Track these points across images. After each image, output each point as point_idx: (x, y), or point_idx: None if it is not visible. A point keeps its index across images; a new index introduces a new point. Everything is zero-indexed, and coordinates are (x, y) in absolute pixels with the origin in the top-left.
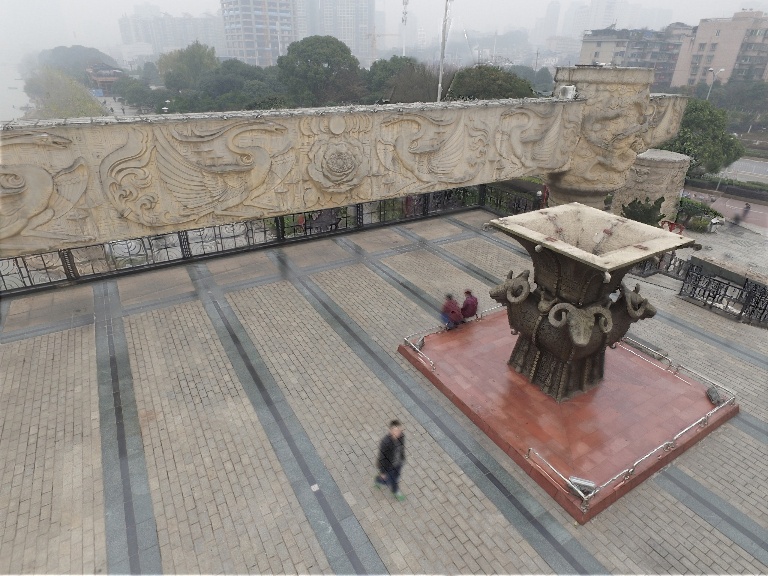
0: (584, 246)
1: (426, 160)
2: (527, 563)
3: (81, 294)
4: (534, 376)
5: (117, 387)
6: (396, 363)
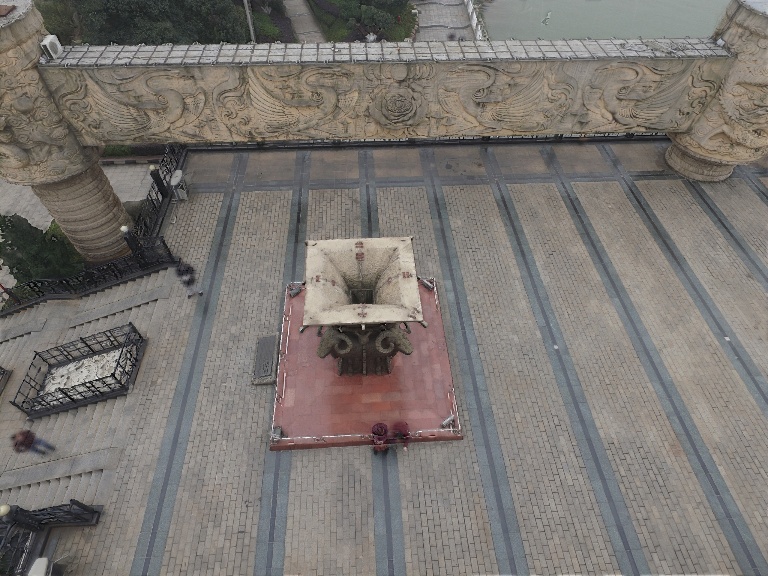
0: (345, 300)
1: None
2: (471, 281)
3: None
4: None
5: (721, 502)
6: (471, 423)
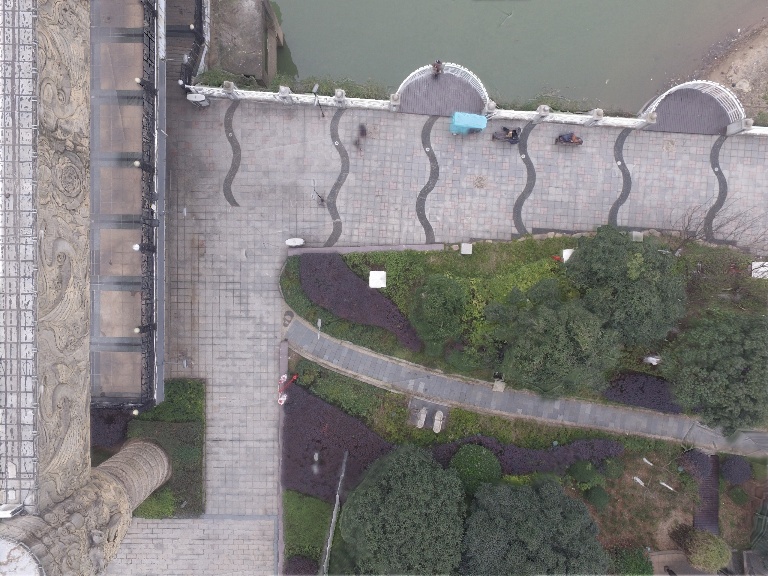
0: None
1: None
2: None
3: (133, 20)
4: None
5: None
6: None
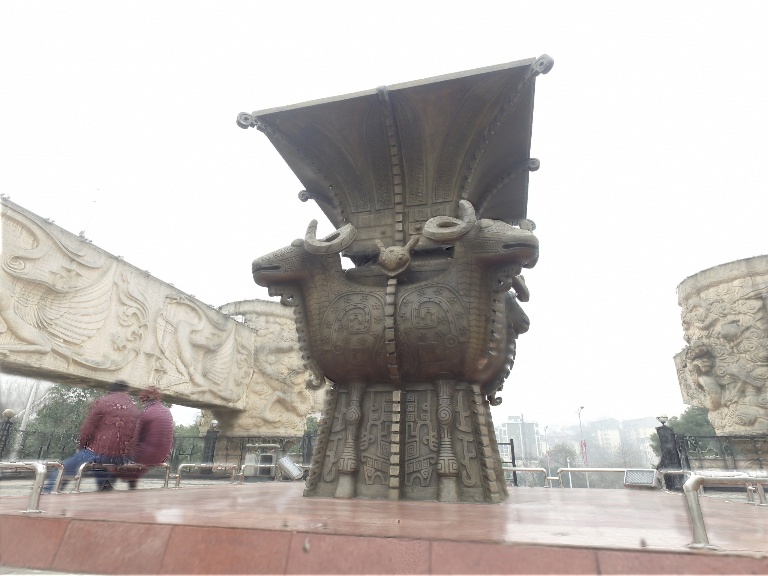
0: None
1: (36, 301)
2: None
3: None
4: (399, 476)
5: None
6: None
